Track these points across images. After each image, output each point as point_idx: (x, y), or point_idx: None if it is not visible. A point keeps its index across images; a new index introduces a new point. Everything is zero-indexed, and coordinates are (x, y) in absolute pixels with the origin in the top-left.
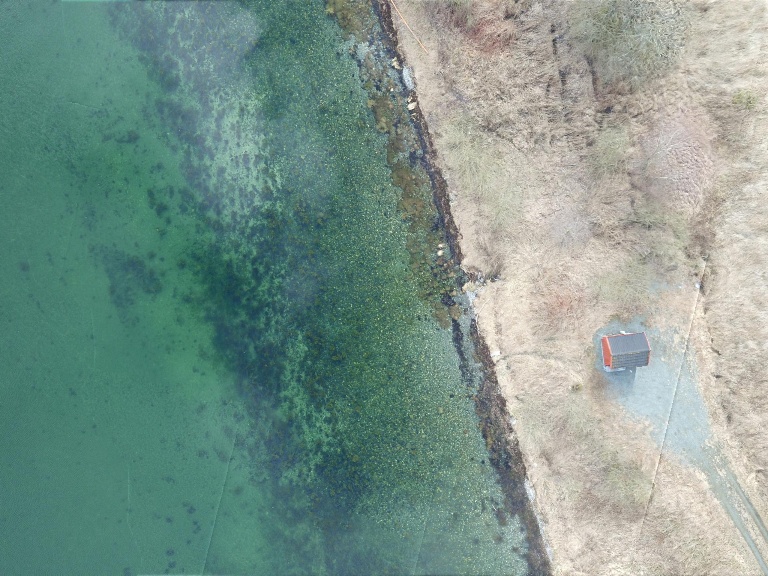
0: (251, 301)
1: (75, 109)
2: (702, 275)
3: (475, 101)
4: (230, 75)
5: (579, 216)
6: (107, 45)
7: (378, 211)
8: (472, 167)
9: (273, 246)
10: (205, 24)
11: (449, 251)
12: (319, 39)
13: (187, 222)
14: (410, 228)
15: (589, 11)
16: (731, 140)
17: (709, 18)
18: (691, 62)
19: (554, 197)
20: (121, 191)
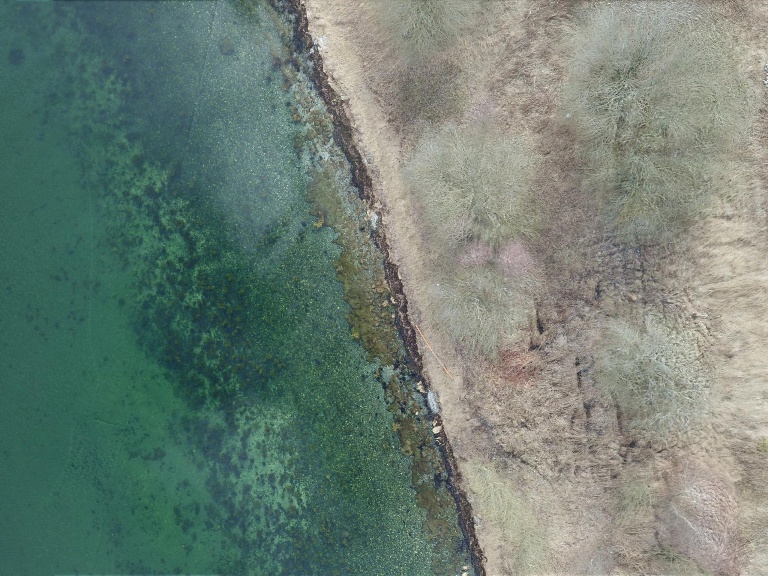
0: None
1: (102, 427)
2: None
3: (500, 428)
4: (256, 395)
5: (603, 545)
6: (133, 364)
7: (403, 531)
8: (497, 494)
9: (299, 565)
10: (231, 346)
11: (474, 573)
12: (344, 361)
13: (213, 538)
14: (435, 549)
15: (614, 347)
16: (755, 486)
17: (734, 365)
18: (715, 405)
19: (578, 526)
20: (147, 508)
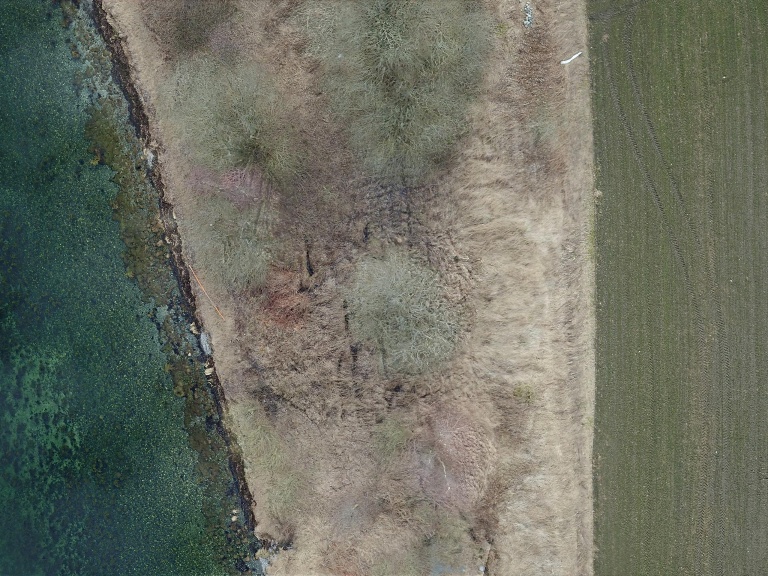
0: (48, 558)
1: None
2: (486, 558)
3: (270, 370)
4: (32, 333)
5: (369, 491)
6: None
7: (175, 473)
8: (265, 437)
9: (70, 506)
10: (7, 283)
11: (243, 516)
12: (119, 301)
13: None
14: (206, 492)
15: None
16: (512, 431)
17: (492, 308)
18: (476, 349)
19: (345, 471)
20: None
